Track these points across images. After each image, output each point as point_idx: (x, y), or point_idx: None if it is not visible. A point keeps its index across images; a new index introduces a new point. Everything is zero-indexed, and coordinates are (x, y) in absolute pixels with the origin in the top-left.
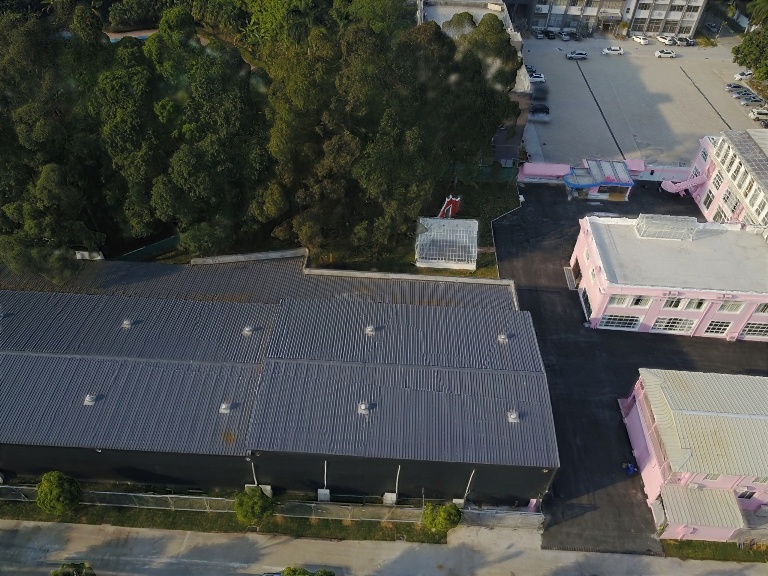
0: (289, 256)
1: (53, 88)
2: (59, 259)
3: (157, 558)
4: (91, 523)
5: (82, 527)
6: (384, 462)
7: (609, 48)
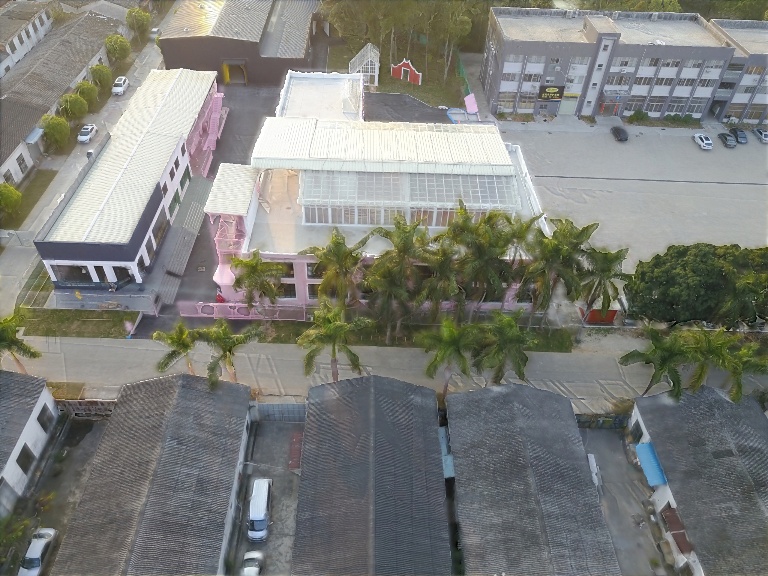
0: None
1: None
2: None
3: None
4: None
5: None
6: None
7: None
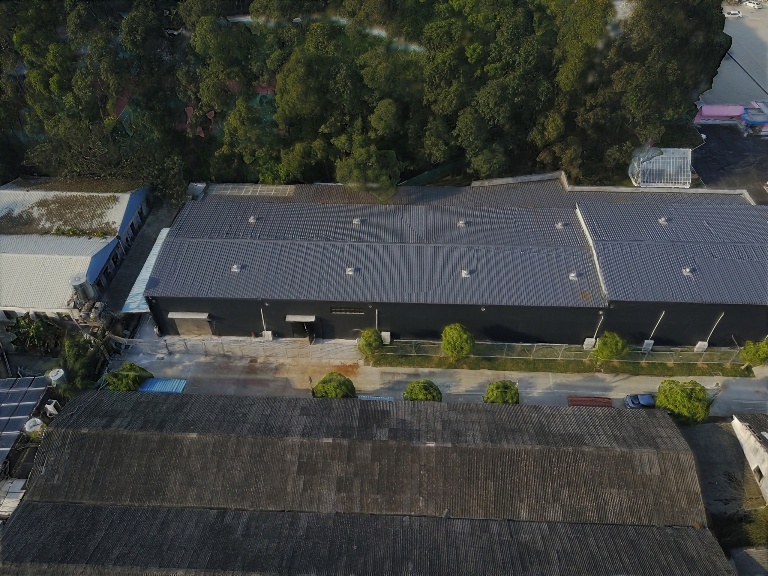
0: (547, 179)
1: (393, 37)
2: (387, 178)
3: (535, 390)
4: (472, 369)
5: (467, 371)
6: (713, 310)
7: (729, 12)
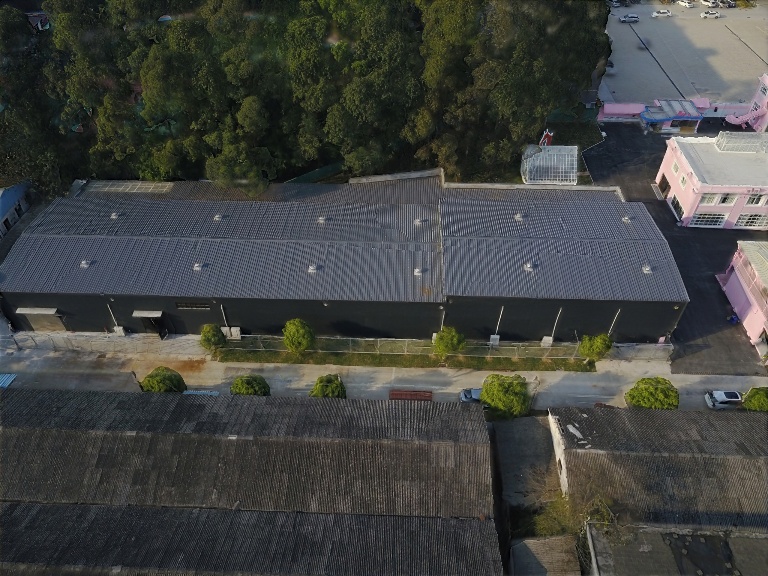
0: (427, 176)
1: (255, 34)
2: (255, 175)
3: (375, 384)
4: (317, 364)
5: (311, 366)
6: (550, 305)
7: (658, 11)
